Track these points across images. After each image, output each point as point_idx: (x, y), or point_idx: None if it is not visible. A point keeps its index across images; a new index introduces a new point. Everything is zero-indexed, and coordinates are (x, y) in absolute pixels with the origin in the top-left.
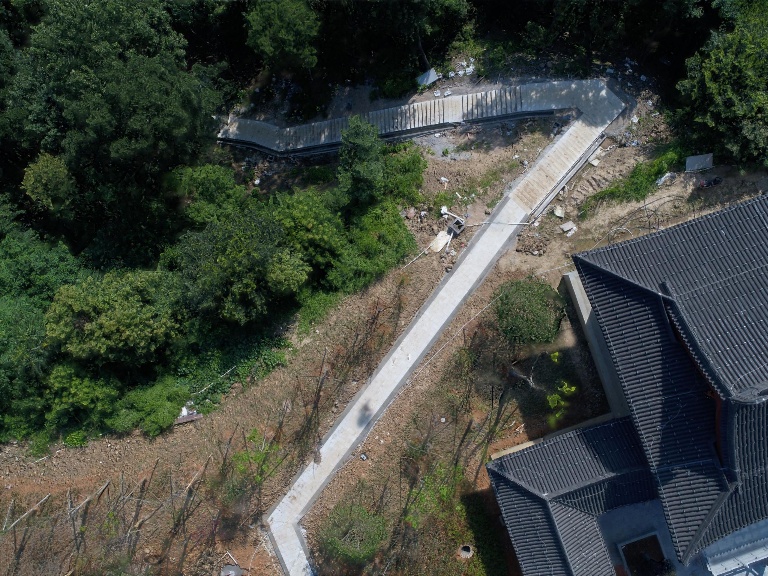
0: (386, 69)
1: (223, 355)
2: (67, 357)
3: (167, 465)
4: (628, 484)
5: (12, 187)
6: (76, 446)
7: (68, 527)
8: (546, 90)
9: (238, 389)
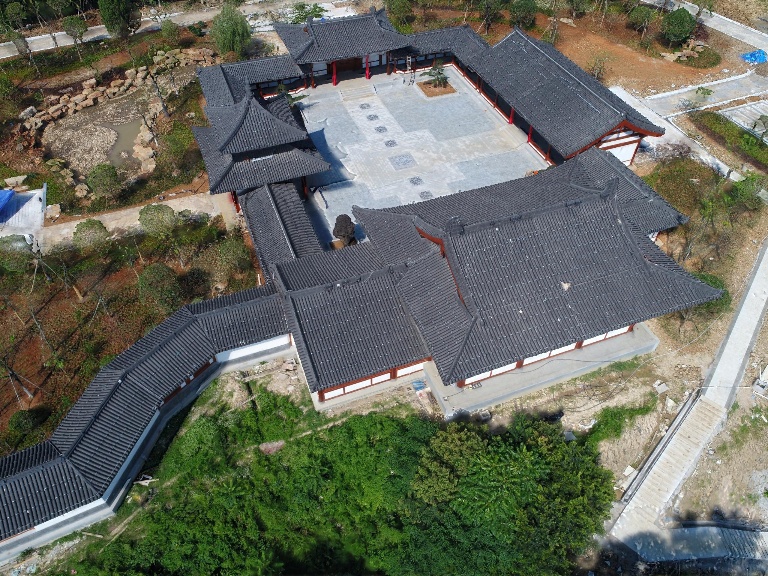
0: None
1: None
2: None
3: None
4: None
5: None
6: None
7: None
8: (701, 549)
9: None
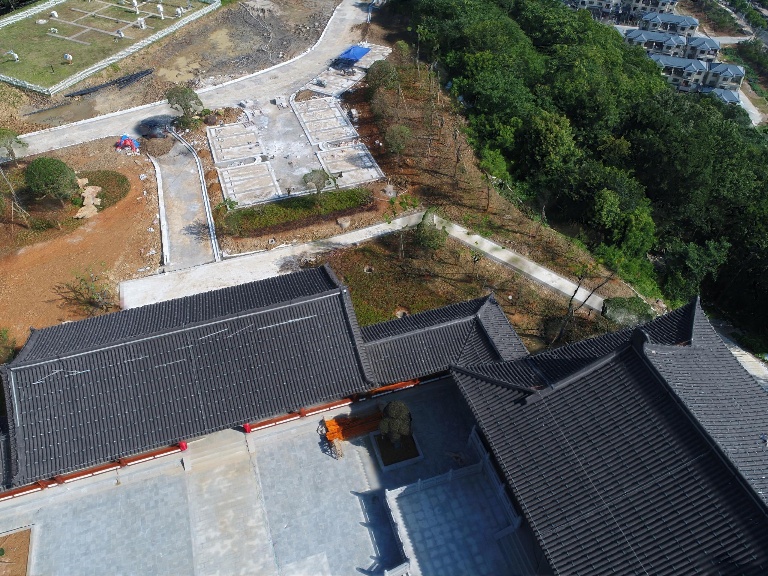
0: (762, 340)
1: (530, 201)
2: (526, 127)
3: None
4: None
5: (595, 157)
6: None
7: None
8: None
9: None
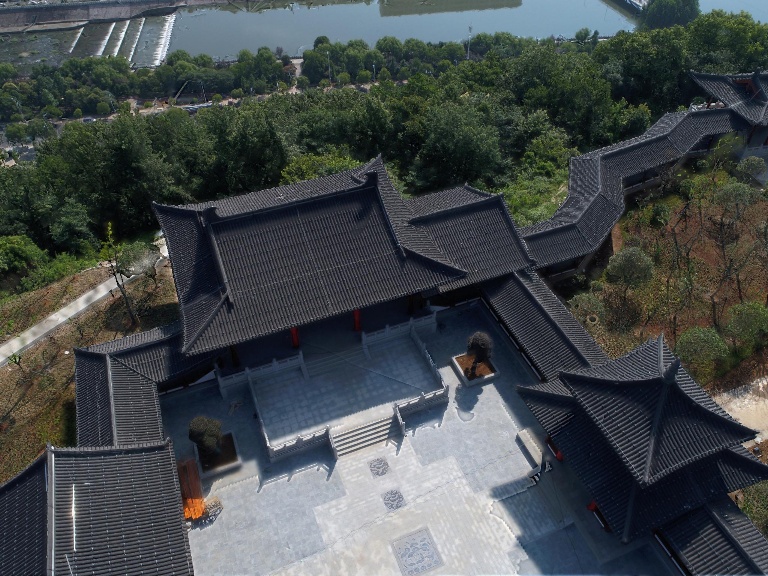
0: (139, 235)
1: None
2: None
3: None
4: None
5: None
6: None
7: None
8: None
9: None
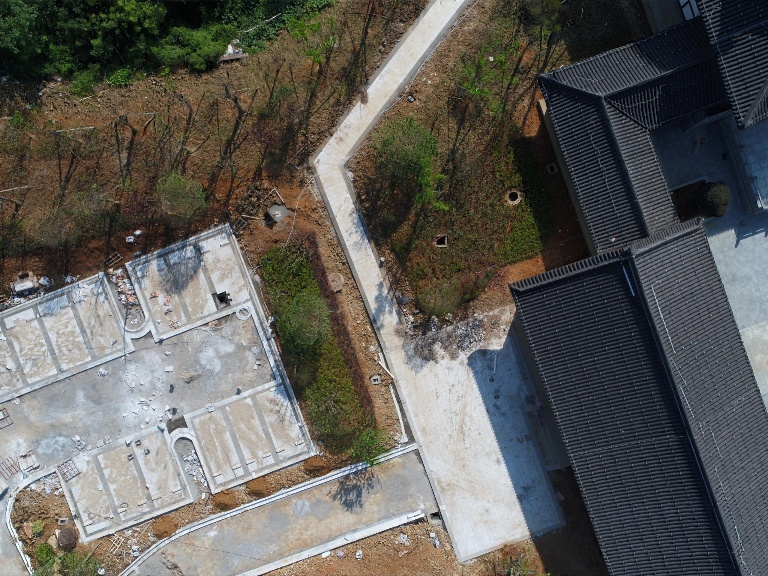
0: None
1: (268, 3)
2: None
3: (214, 97)
4: (683, 88)
5: None
6: (120, 85)
7: (114, 159)
8: None
9: (283, 35)
